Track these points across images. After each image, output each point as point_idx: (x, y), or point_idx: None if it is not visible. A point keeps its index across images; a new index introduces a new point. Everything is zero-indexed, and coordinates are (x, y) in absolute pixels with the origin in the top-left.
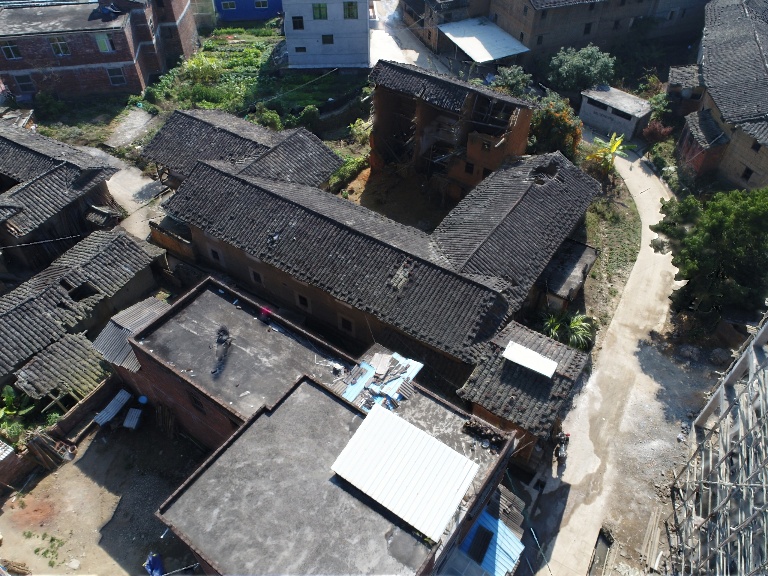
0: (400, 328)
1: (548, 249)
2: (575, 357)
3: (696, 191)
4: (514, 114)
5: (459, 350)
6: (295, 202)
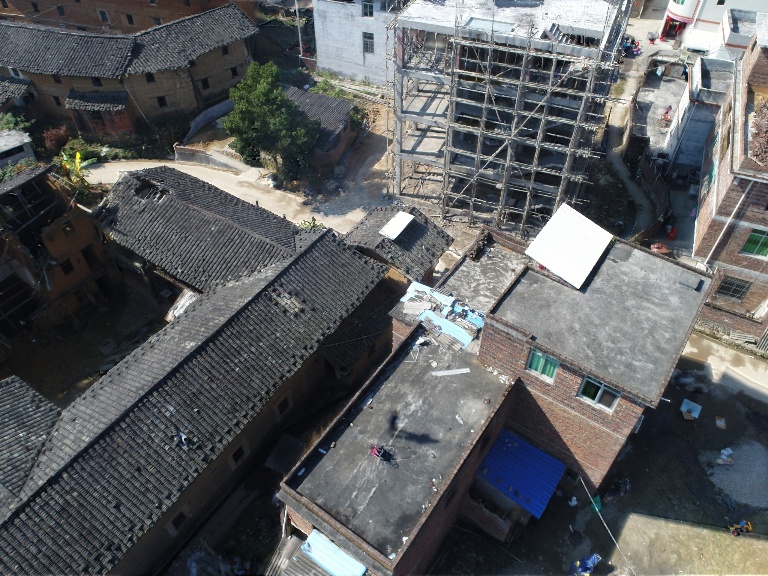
0: (345, 316)
1: (254, 208)
2: (381, 210)
3: (149, 142)
4: (56, 180)
5: (377, 273)
6: (135, 401)
